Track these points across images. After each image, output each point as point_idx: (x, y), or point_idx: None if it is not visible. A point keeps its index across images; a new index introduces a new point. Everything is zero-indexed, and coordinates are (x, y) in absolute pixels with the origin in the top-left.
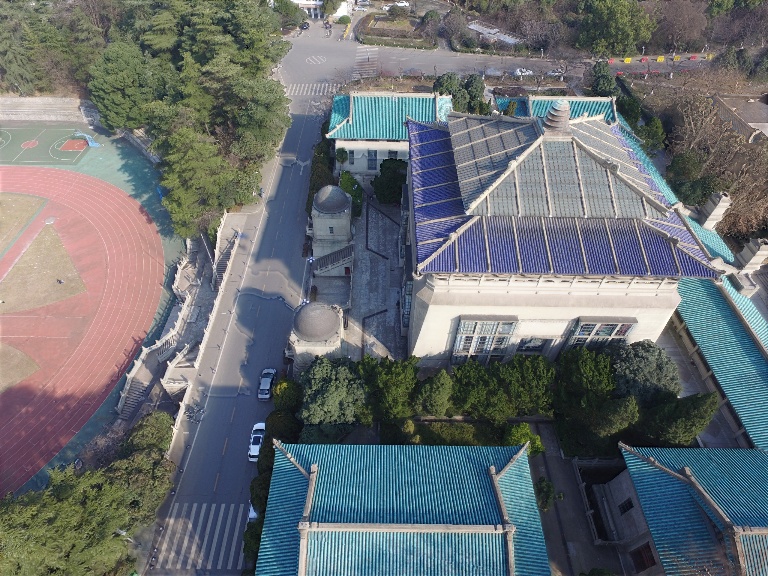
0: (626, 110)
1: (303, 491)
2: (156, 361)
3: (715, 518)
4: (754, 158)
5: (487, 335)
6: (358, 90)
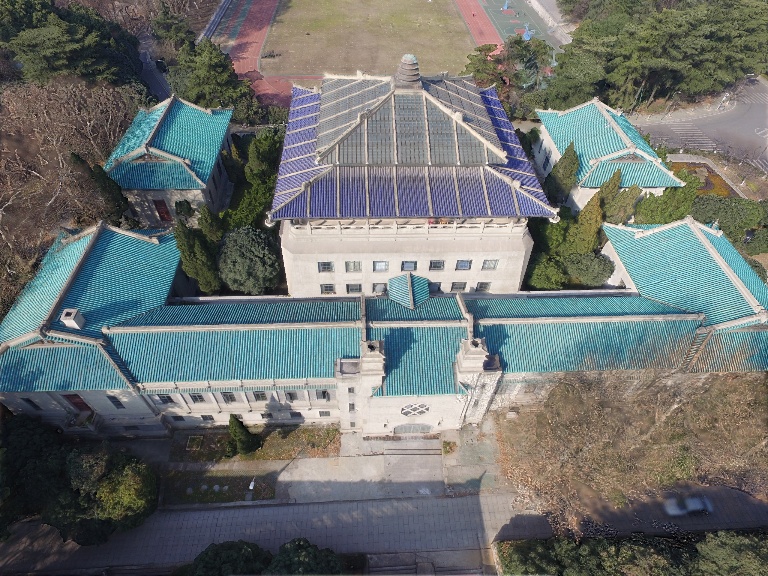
0: None
1: None
2: None
3: None
4: None
5: None
6: (714, 161)
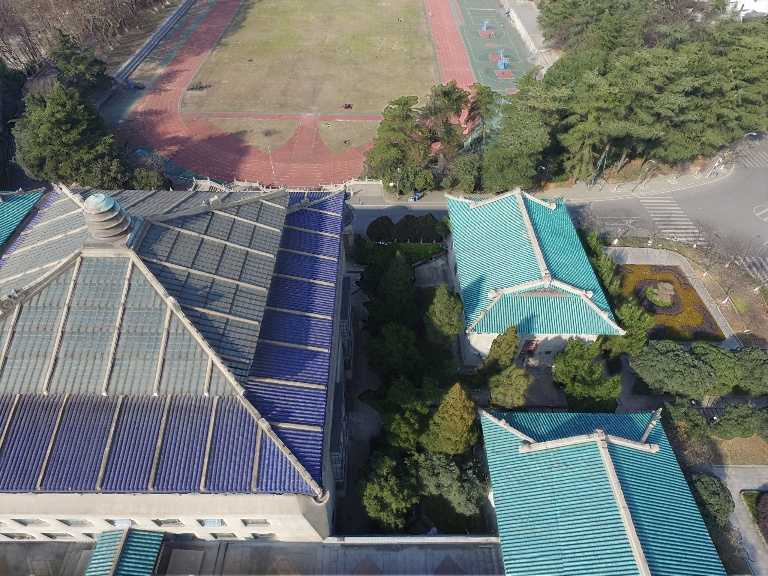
0: None
1: None
2: None
3: None
4: None
5: None
6: (691, 261)
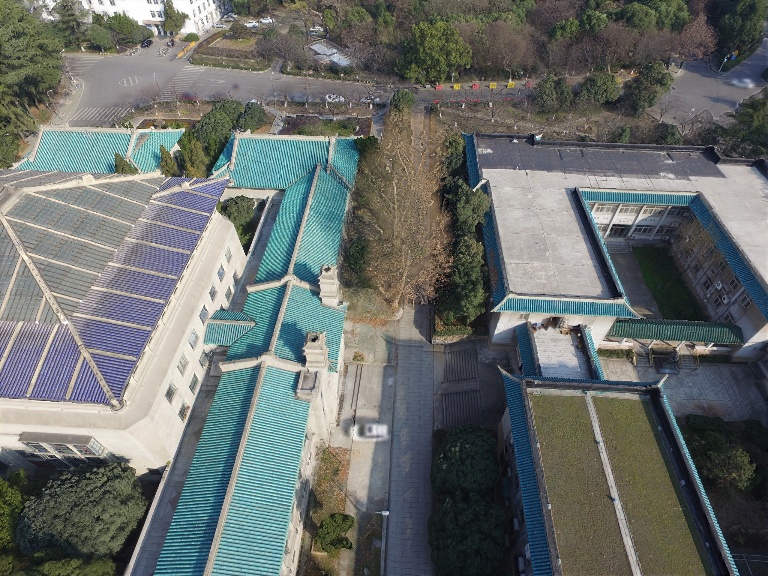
0: (361, 150)
1: None
2: None
3: None
4: (456, 214)
5: None
6: (143, 116)
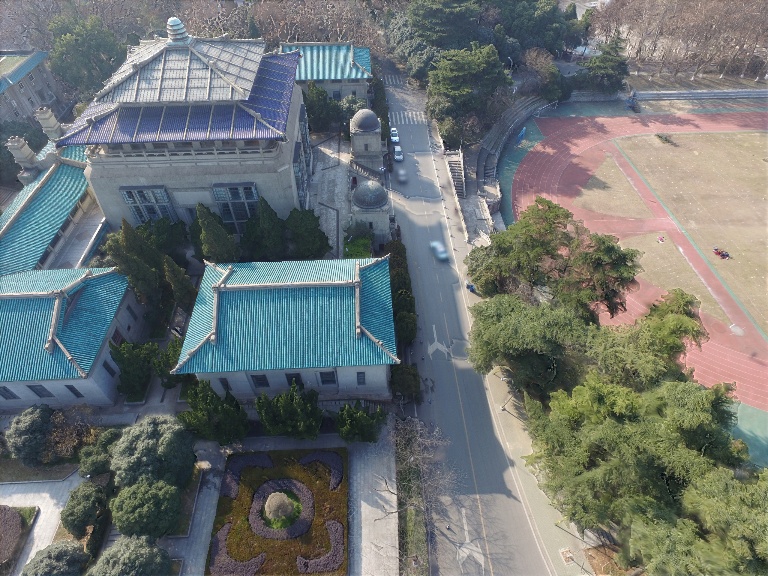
0: None
1: None
2: (489, 197)
3: None
4: None
5: None
6: None
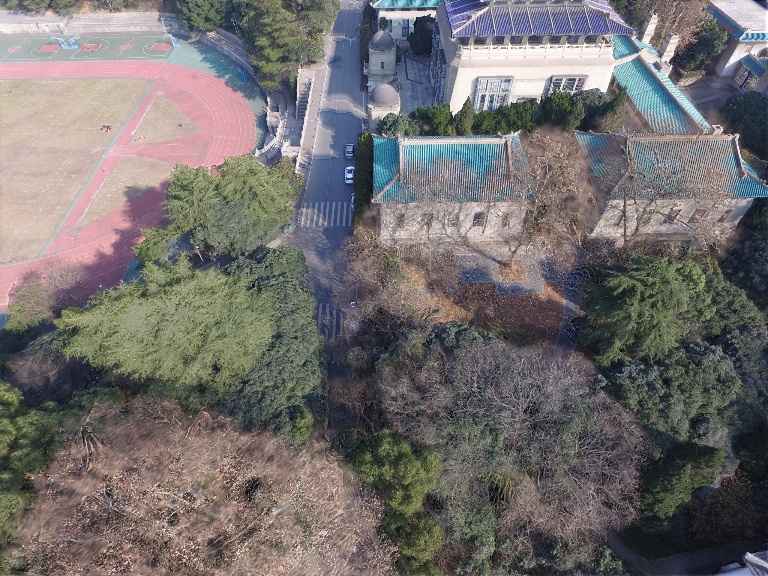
0: None
1: (394, 145)
2: (266, 158)
3: (620, 140)
4: (687, 6)
5: (494, 93)
6: None
